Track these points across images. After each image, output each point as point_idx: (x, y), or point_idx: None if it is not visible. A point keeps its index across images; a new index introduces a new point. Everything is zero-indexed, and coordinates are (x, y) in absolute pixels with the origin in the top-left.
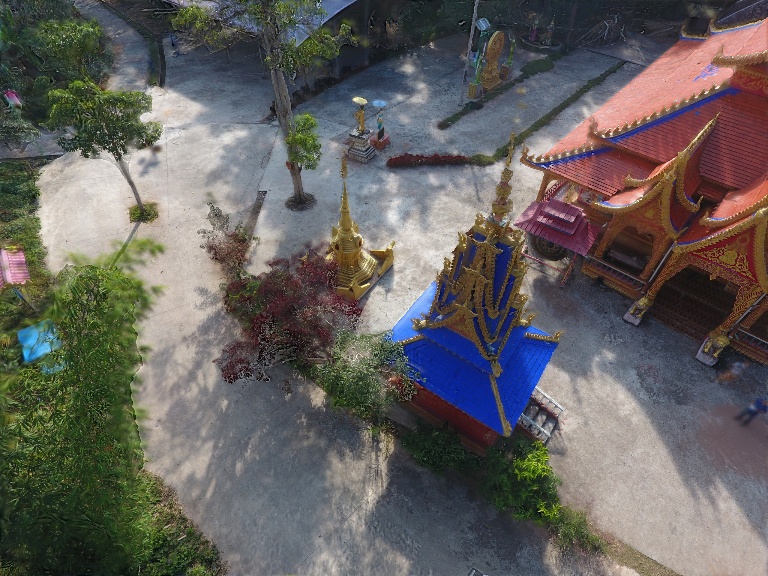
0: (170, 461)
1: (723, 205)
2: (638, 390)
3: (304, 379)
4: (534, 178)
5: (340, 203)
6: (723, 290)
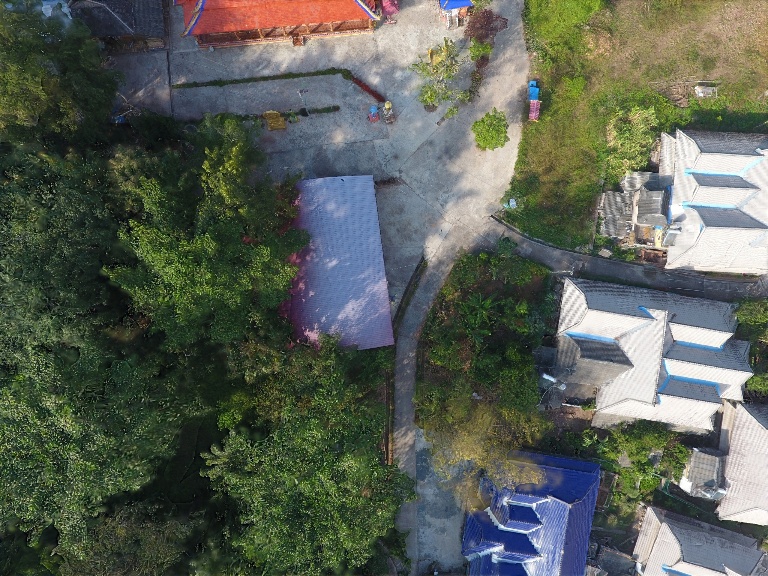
0: (520, 42)
1: None
2: None
3: None
4: (340, 49)
5: None
6: None
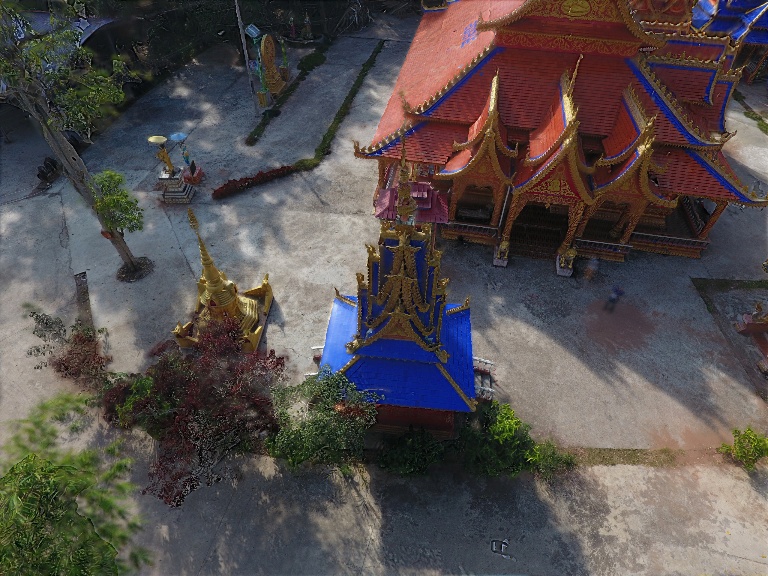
0: None
1: (532, 145)
2: (533, 319)
3: (243, 456)
4: (362, 167)
5: (182, 255)
6: (549, 213)
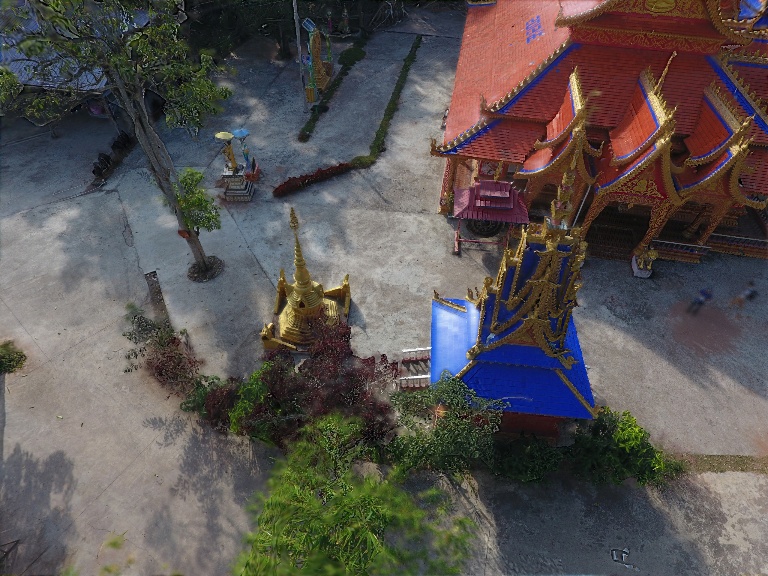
0: None
1: (615, 144)
2: (617, 322)
3: None
4: (419, 165)
5: (252, 254)
6: (618, 212)
